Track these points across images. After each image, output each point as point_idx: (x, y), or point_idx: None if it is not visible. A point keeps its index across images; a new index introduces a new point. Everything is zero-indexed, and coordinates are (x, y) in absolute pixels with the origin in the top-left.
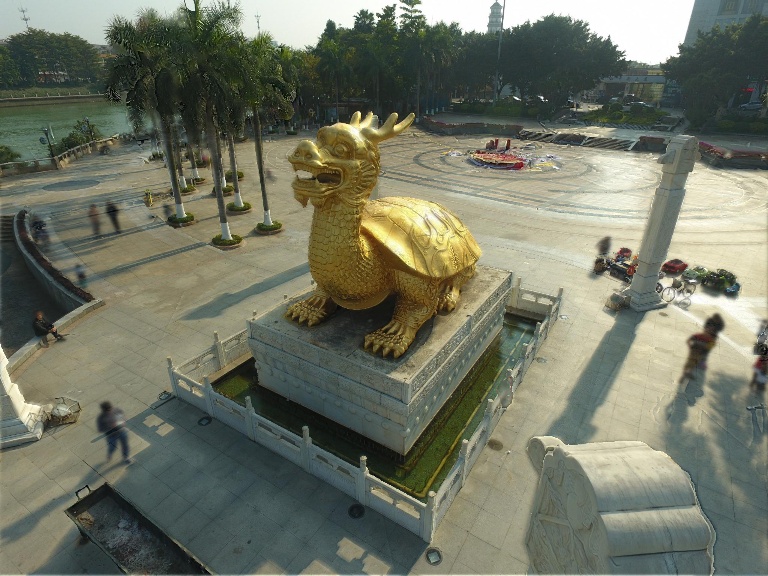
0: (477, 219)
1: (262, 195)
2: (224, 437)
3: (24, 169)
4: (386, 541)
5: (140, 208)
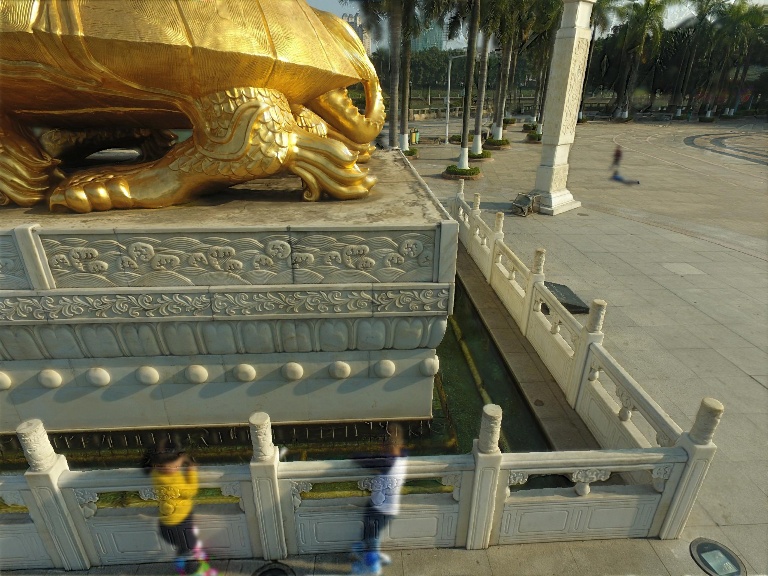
0: None
1: (463, 125)
2: None
3: None
4: None
5: None
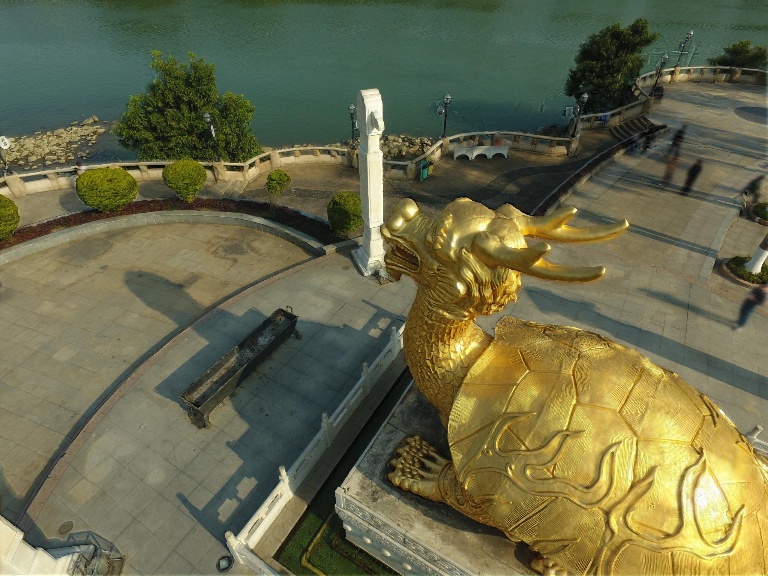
0: None
1: None
2: None
3: (763, 80)
4: (247, 517)
5: (762, 175)
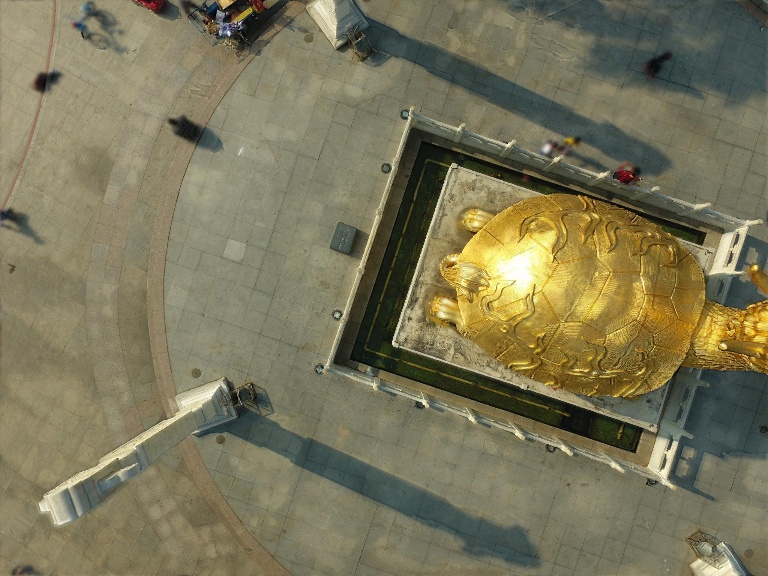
0: (3, 242)
1: None
2: (684, 400)
3: None
4: None
5: None
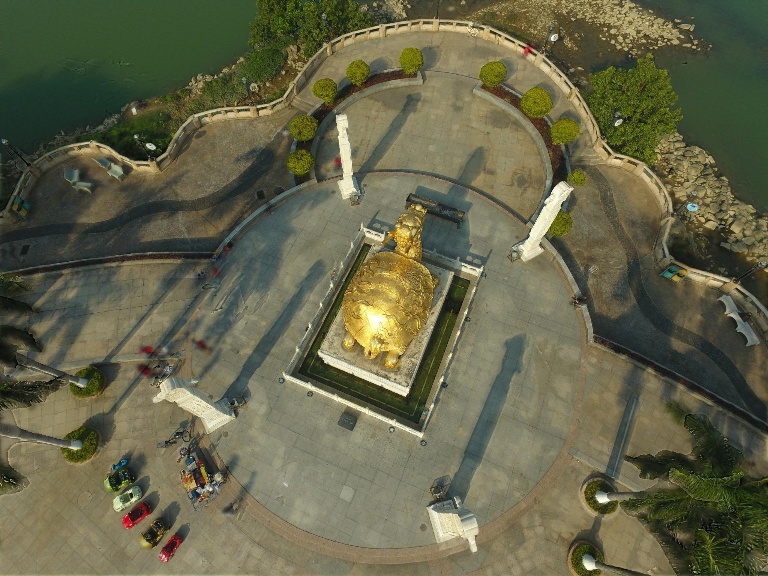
0: None
1: None
2: None
3: None
4: None
5: None
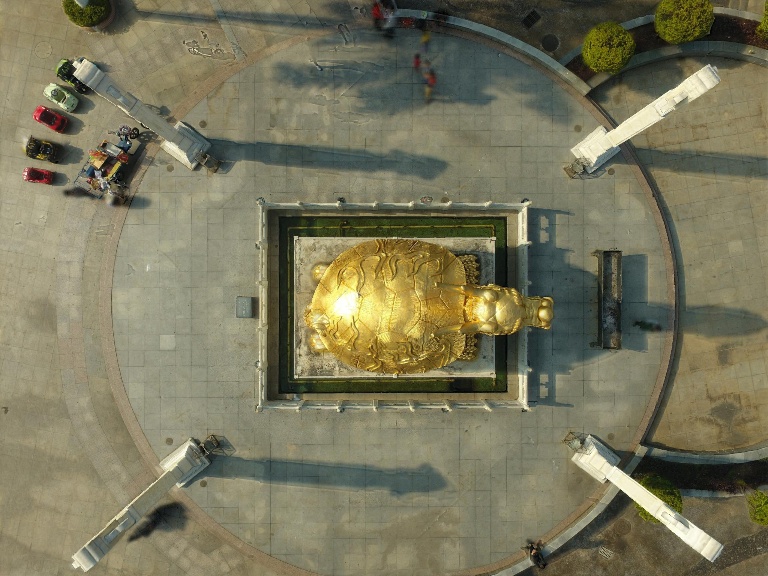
0: None
1: None
2: (529, 343)
3: None
4: (532, 225)
5: None
